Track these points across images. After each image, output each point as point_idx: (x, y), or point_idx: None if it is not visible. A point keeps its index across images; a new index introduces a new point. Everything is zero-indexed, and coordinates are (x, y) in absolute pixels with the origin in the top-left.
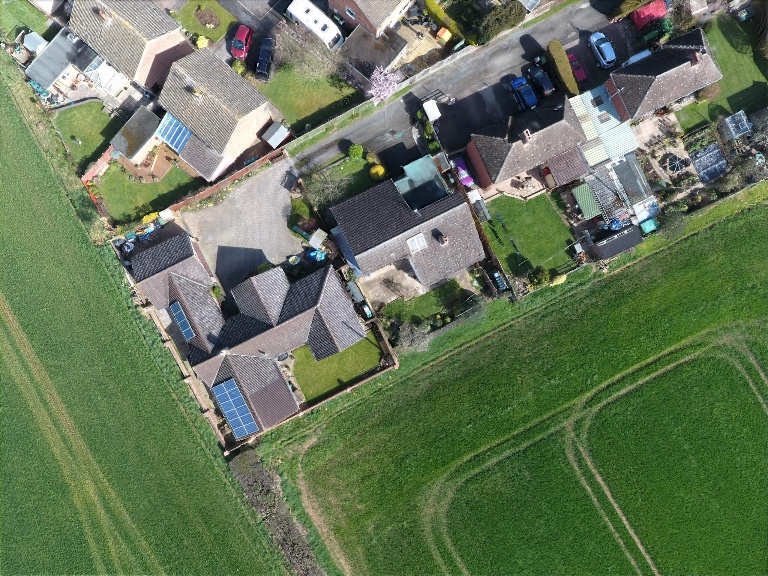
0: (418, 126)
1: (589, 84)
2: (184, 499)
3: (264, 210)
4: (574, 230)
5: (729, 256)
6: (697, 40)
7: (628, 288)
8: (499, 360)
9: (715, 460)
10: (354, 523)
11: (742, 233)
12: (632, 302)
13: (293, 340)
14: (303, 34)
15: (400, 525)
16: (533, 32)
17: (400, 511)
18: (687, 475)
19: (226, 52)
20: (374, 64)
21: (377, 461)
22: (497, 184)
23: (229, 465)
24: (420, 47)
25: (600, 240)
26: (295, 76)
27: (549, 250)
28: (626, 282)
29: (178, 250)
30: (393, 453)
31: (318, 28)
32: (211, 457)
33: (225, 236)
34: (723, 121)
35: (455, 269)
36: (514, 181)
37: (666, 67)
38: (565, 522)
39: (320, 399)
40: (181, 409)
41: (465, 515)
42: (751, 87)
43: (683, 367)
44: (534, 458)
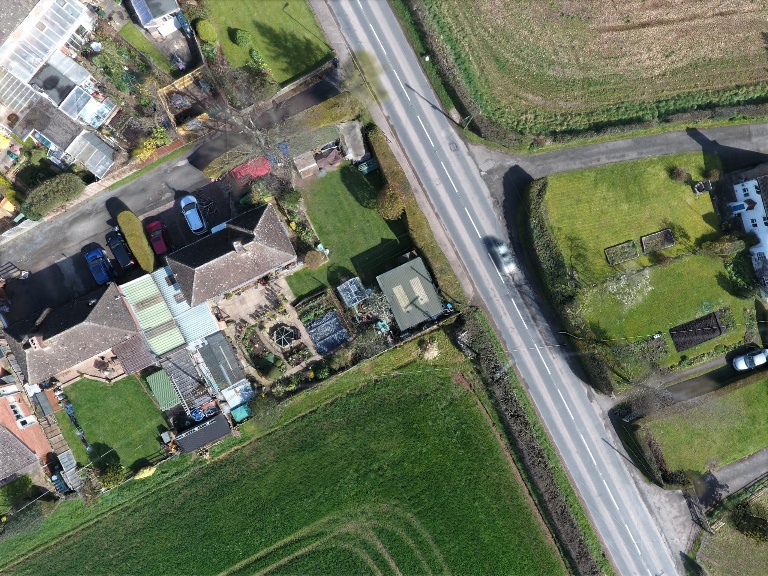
0: None
1: None
2: None
3: None
4: (167, 414)
5: (351, 435)
6: (254, 222)
7: (233, 475)
8: (79, 564)
9: None
10: None
11: (367, 409)
12: (237, 491)
13: None
14: None
15: None
16: (122, 194)
17: None
18: None
19: None
20: None
21: None
22: (74, 367)
23: None
24: None
25: (178, 433)
26: None
27: (138, 438)
28: (231, 468)
29: None
30: None
31: None
32: None
33: None
34: (337, 288)
35: (0, 475)
36: (98, 362)
37: (210, 256)
38: None
39: None
40: None
41: None
42: (379, 245)
43: (298, 561)
44: None
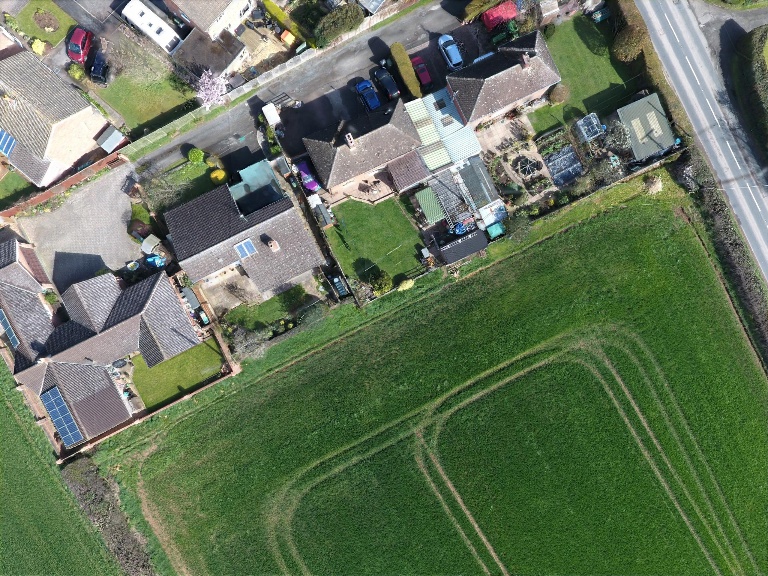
0: (262, 130)
1: (439, 87)
2: (19, 508)
3: (103, 215)
4: (423, 234)
5: (584, 260)
6: (531, 42)
7: (480, 293)
8: (346, 366)
9: (569, 466)
10: (195, 531)
11: (597, 237)
12: (484, 307)
13: (122, 347)
14: (142, 37)
15: (243, 533)
16: (382, 34)
17: (243, 519)
18: (540, 481)
19: (65, 56)
20: (211, 67)
21: (219, 469)
22: (343, 188)
23: (62, 474)
24: (265, 50)
25: (443, 245)
26: (137, 80)
27: (398, 255)
28: (478, 287)
29: (2, 257)
30: (235, 460)
31: (153, 31)
32: (47, 465)
33: (62, 242)
34: (575, 124)
35: (292, 275)
36: (362, 185)
37: (496, 70)
38: (414, 529)
39: (160, 406)
40: (15, 417)
41: (311, 523)
42: (608, 89)
43: (536, 372)
44: (382, 465)
